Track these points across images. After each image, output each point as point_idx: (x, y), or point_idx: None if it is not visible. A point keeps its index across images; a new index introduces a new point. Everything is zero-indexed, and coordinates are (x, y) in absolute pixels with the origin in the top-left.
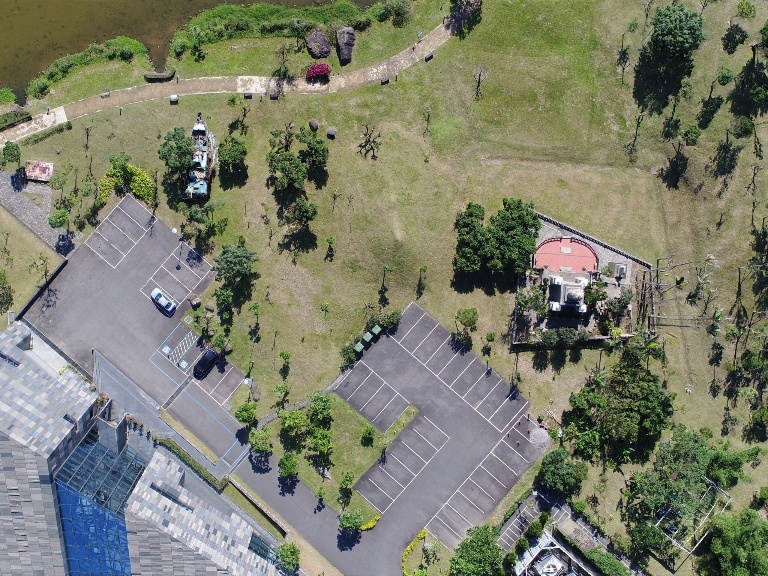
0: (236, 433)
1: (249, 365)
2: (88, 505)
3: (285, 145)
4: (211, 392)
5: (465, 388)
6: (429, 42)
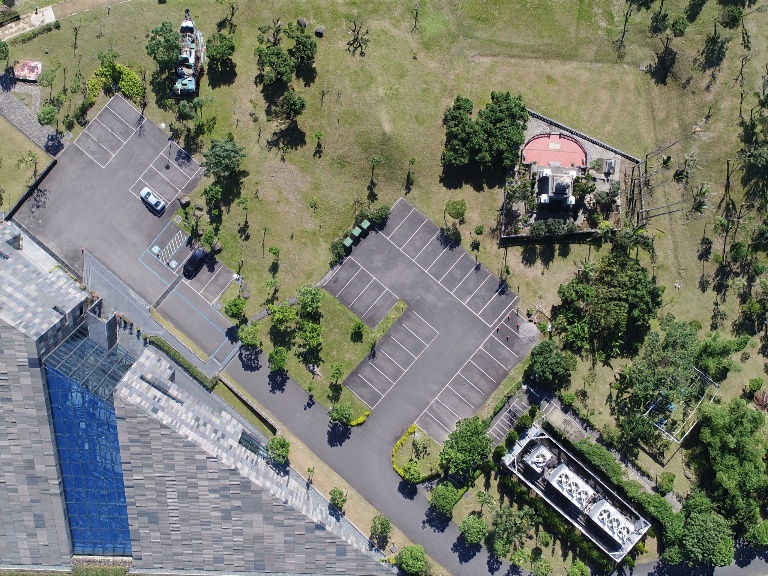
0: (226, 332)
1: (239, 264)
2: (77, 391)
3: (273, 43)
4: (201, 291)
5: (454, 283)
6: None
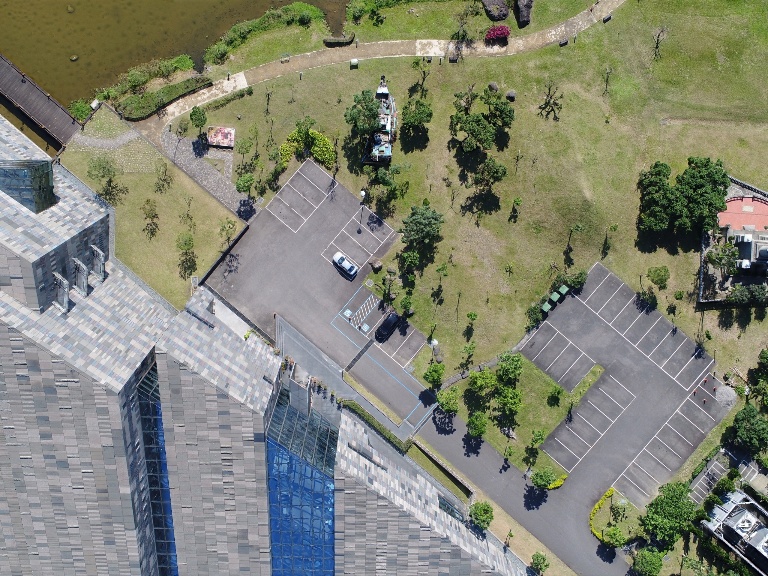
0: (419, 395)
1: (431, 327)
2: None
3: (465, 108)
4: (393, 355)
5: (651, 347)
6: (607, 3)
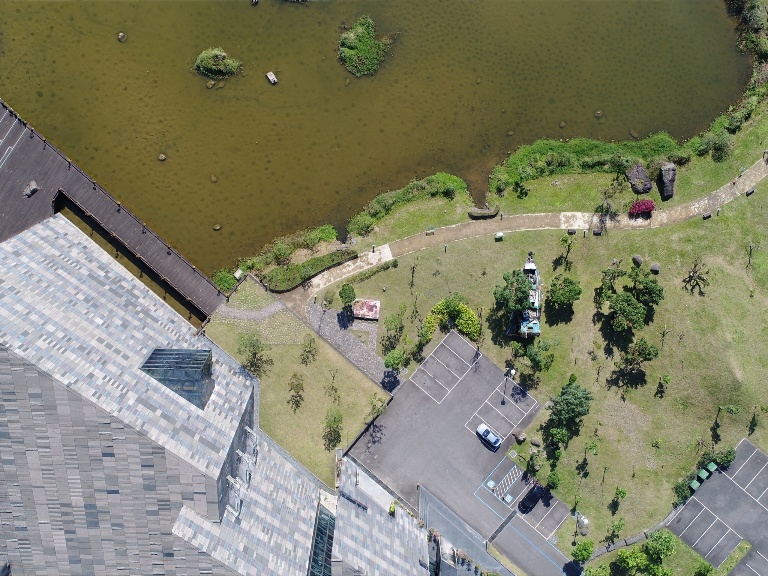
0: (563, 567)
1: (575, 499)
2: None
3: None
4: (536, 526)
5: None
6: (750, 177)
